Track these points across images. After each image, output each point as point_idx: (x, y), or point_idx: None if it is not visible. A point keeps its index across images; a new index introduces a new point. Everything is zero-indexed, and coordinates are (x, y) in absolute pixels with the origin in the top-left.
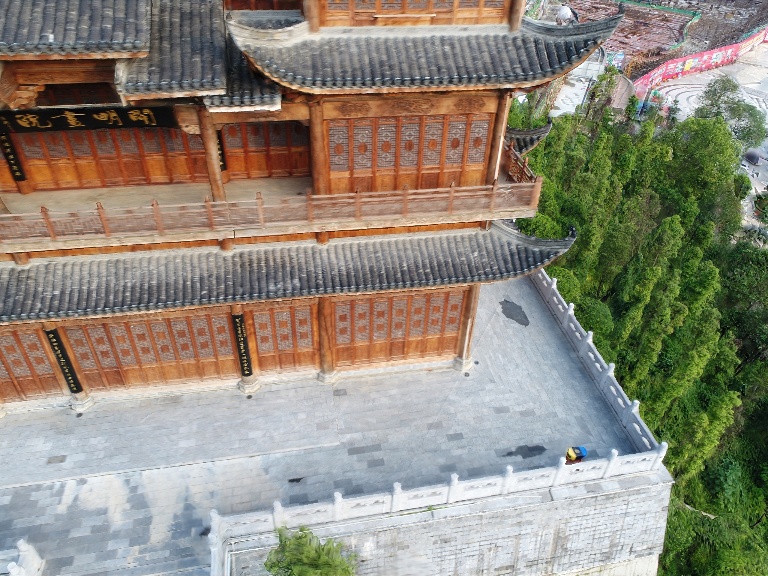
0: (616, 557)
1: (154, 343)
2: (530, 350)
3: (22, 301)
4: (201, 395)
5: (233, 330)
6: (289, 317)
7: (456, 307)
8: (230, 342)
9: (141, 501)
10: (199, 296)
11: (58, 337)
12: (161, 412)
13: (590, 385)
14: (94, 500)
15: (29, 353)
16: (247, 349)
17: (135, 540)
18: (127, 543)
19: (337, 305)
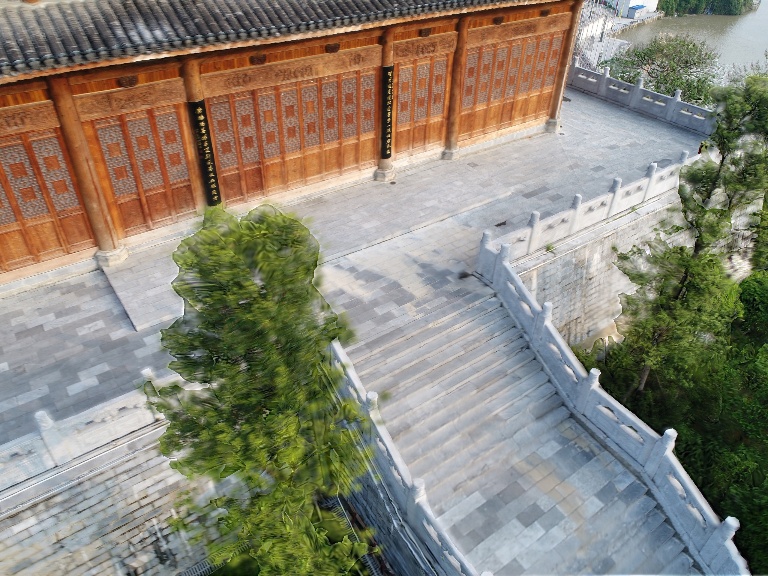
0: (734, 247)
1: (301, 120)
2: (590, 113)
3: (205, 23)
4: (342, 192)
5: (379, 94)
6: (428, 72)
7: (556, 53)
8: (373, 112)
9: (371, 275)
10: (394, 8)
11: (205, 114)
12: (315, 212)
13: (657, 122)
14: (319, 288)
15: (164, 148)
16: (391, 119)
17: (400, 300)
18: (394, 304)
19: (469, 54)
